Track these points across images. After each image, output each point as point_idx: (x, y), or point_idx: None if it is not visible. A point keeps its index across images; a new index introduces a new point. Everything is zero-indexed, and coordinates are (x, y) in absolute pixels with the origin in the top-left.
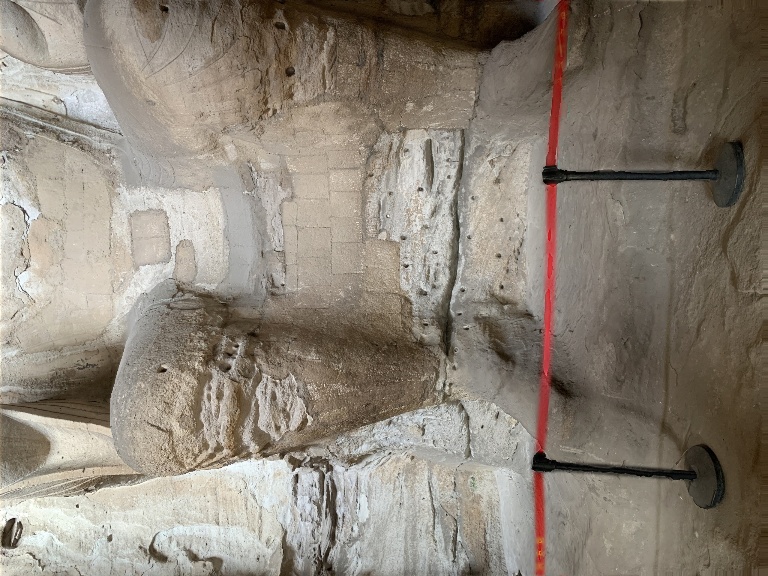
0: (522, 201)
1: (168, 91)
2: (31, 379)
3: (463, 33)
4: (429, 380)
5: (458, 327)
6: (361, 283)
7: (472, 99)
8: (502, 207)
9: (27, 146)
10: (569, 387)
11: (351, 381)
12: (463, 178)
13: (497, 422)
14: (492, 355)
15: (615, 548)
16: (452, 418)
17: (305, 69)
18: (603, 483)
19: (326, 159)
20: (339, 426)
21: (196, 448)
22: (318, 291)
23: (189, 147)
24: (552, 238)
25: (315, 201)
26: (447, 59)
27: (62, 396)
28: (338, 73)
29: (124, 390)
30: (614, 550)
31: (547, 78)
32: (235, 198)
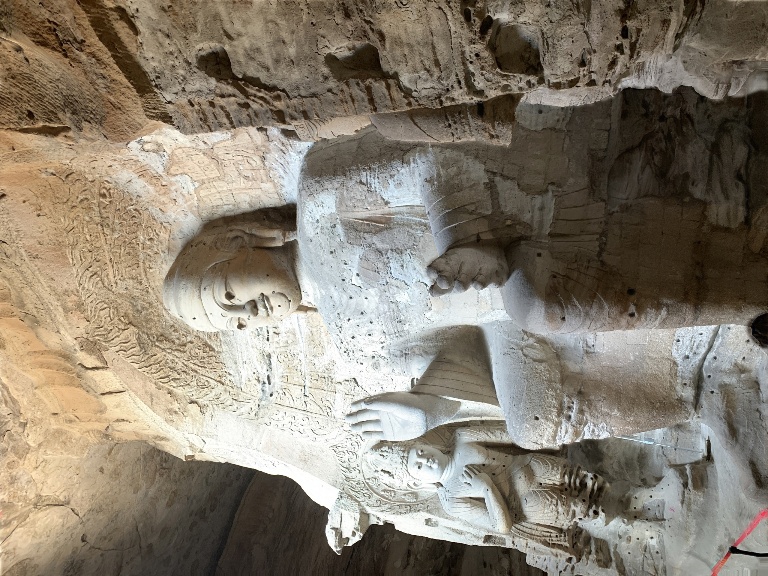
0: None
1: None
2: (425, 337)
3: (765, 246)
4: None
5: (706, 389)
6: (645, 351)
7: None
8: None
9: (420, 243)
10: (764, 481)
11: (636, 426)
12: None
13: None
14: (725, 425)
15: (763, 537)
16: None
17: None
18: (767, 518)
19: None
20: None
21: None
22: (617, 354)
23: None
24: None
25: None
26: (744, 314)
27: (446, 350)
28: None
29: (517, 424)
30: (762, 537)
31: None
32: None
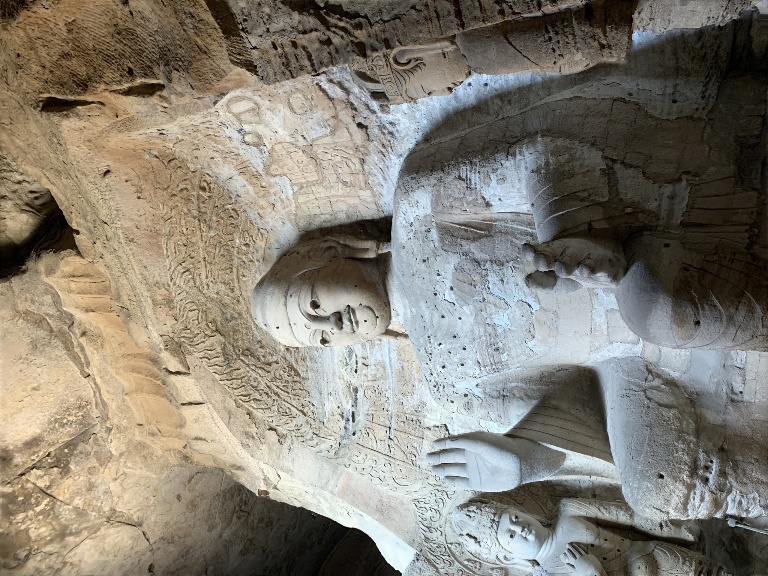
0: None
1: None
2: (528, 378)
3: None
4: None
5: None
6: None
7: None
8: None
9: None
10: None
11: None
12: None
13: None
14: None
15: None
16: None
17: None
18: None
19: None
20: None
21: None
22: None
23: None
24: None
25: None
26: None
27: (552, 395)
28: None
29: (635, 481)
30: None
31: None
32: None
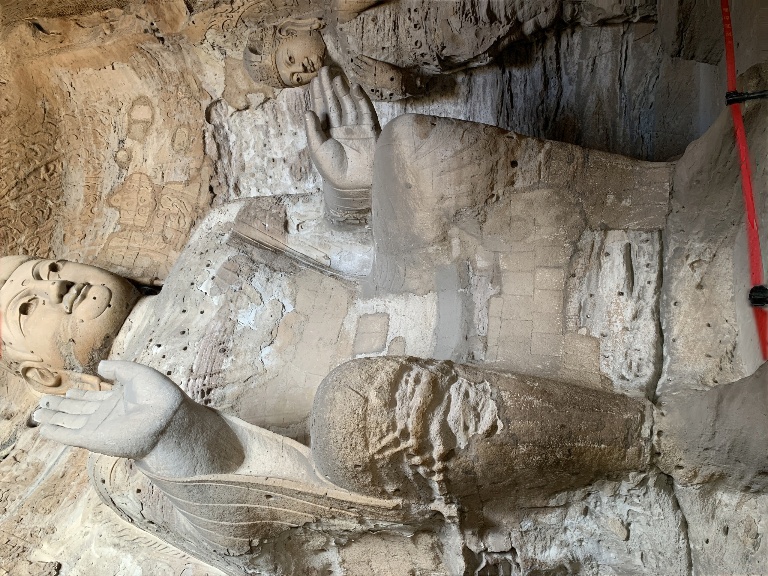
0: (730, 308)
1: (423, 174)
2: None
3: None
4: (633, 419)
5: (666, 394)
6: (559, 362)
7: (667, 190)
8: (708, 312)
9: (299, 273)
10: None
11: (546, 397)
12: (664, 285)
13: (727, 539)
14: None
15: None
16: (665, 516)
17: (526, 163)
18: None
19: (534, 256)
20: (529, 448)
21: (385, 425)
22: (516, 363)
23: (425, 237)
24: (765, 308)
25: (520, 298)
26: (642, 164)
27: None
28: (551, 166)
29: None
30: None
31: (730, 126)
32: (450, 299)
